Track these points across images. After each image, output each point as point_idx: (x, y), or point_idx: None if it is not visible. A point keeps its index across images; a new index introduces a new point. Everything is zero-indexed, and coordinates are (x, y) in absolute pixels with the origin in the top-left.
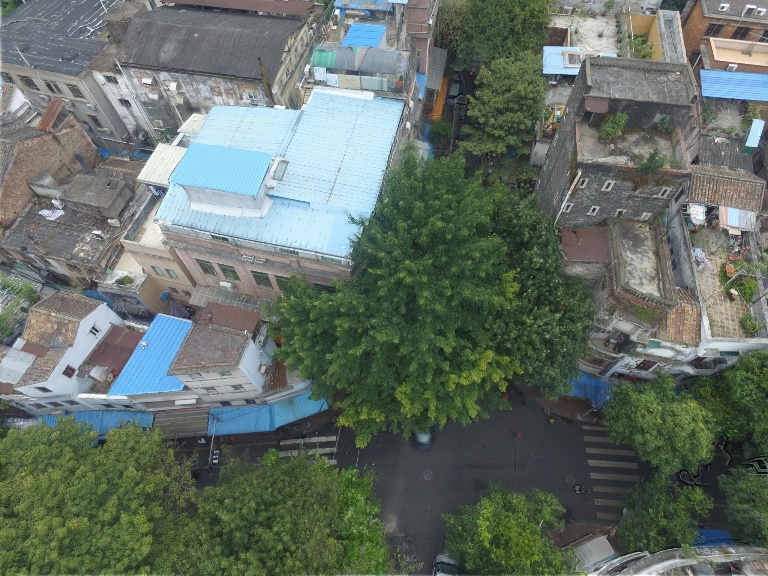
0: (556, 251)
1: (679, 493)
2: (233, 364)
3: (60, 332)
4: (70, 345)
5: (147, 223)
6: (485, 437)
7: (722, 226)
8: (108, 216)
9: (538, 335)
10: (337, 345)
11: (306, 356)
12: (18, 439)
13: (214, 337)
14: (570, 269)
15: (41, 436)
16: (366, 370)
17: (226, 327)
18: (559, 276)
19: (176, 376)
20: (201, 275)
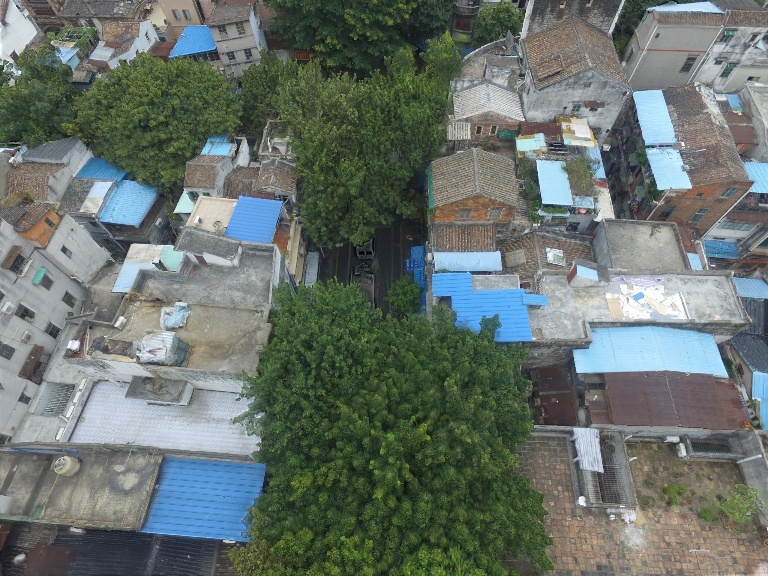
0: None
1: None
2: (246, 16)
3: (127, 32)
4: None
5: None
6: None
7: None
8: None
9: None
10: None
11: None
12: (125, 66)
13: (230, 8)
14: None
15: (141, 56)
16: (325, 8)
17: (236, 4)
18: None
19: (212, 32)
20: (209, 5)
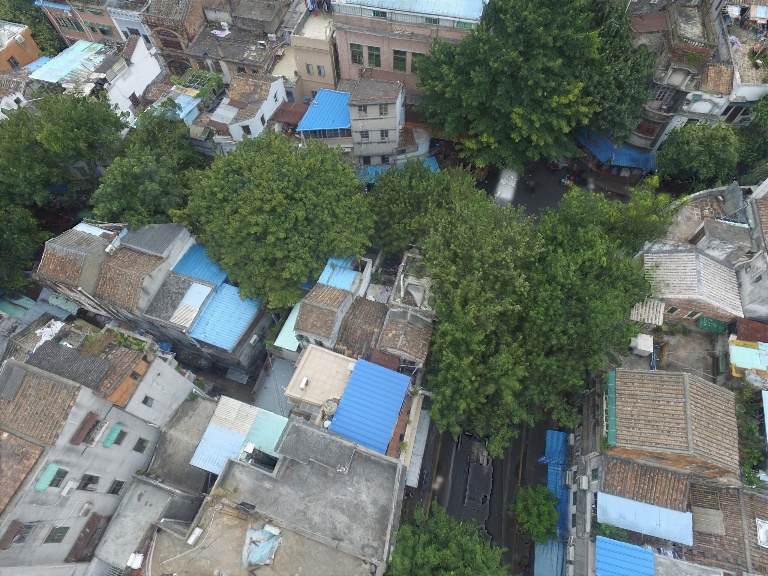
0: (627, 26)
1: None
2: (393, 98)
3: (256, 92)
4: (265, 99)
5: (304, 30)
6: None
7: (752, 18)
8: (268, 31)
9: (614, 79)
10: (476, 70)
11: (453, 79)
12: (248, 141)
13: (377, 84)
14: (636, 42)
15: (268, 134)
16: (489, 101)
17: (384, 79)
18: (629, 43)
19: (350, 111)
20: (348, 65)
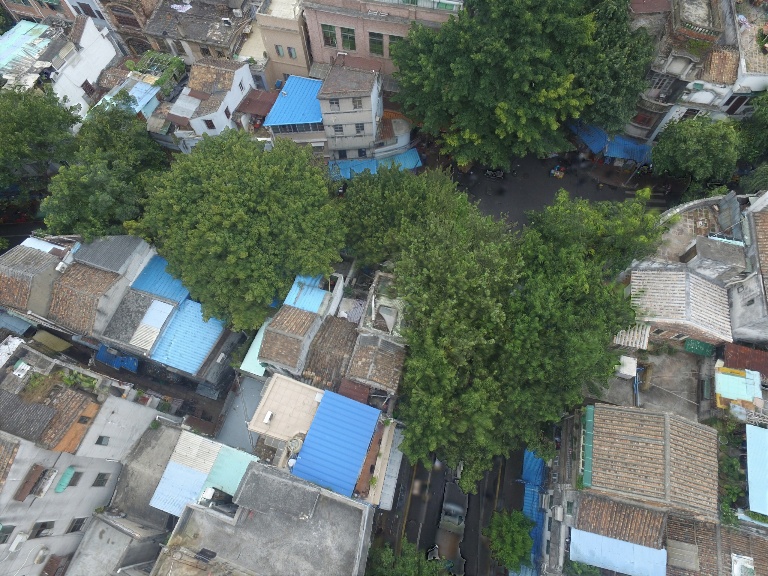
0: (626, 6)
1: (708, 194)
2: (367, 91)
3: (219, 81)
4: (228, 90)
5: (272, 6)
6: (545, 198)
7: None
8: (233, 7)
9: (608, 69)
10: (456, 61)
11: (432, 71)
12: (209, 141)
13: (349, 74)
14: (635, 24)
15: (230, 134)
16: (472, 94)
17: (357, 68)
18: (627, 26)
19: (320, 104)
20: (321, 48)
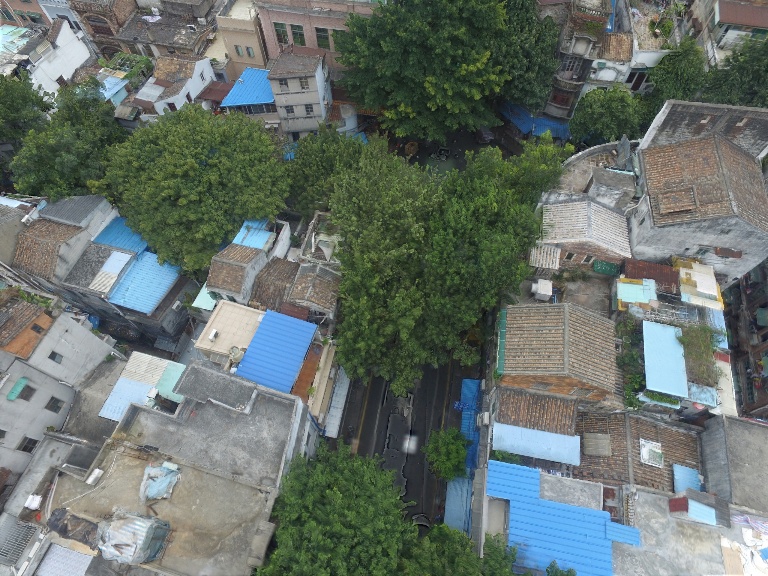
0: None
1: None
2: (312, 71)
3: (181, 71)
4: (190, 77)
5: (232, 12)
6: None
7: None
8: (198, 16)
9: (521, 48)
10: (387, 41)
11: (366, 50)
12: (170, 115)
13: (297, 59)
14: (543, 15)
15: (188, 107)
16: (404, 72)
17: (304, 54)
18: (535, 15)
19: (271, 85)
20: (275, 45)
